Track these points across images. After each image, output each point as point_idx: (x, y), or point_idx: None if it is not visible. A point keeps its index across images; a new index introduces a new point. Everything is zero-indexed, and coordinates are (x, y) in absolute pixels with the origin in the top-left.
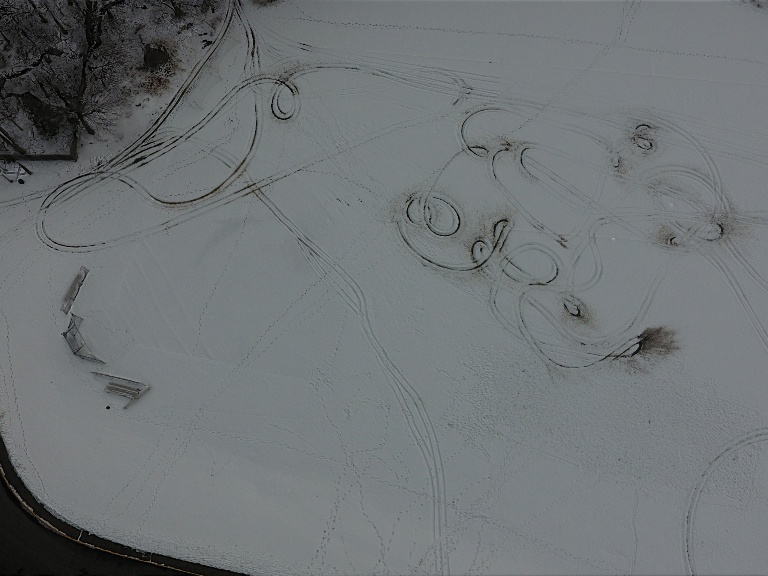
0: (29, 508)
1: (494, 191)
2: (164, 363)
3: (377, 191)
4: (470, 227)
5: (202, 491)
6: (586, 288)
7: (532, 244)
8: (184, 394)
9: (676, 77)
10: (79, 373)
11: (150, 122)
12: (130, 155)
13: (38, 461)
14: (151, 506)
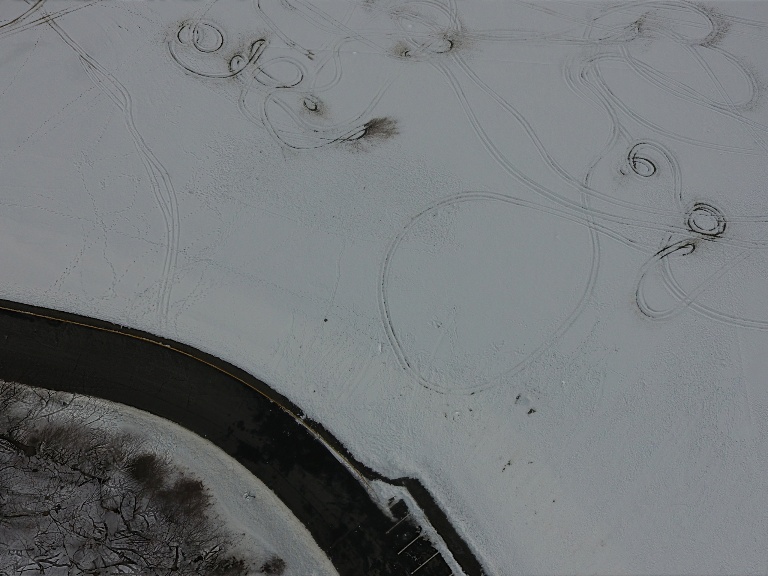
0: None
1: (256, 18)
2: None
3: (154, 19)
4: (231, 45)
5: None
6: (325, 89)
7: (283, 57)
8: None
9: None
10: None
11: None
12: None
13: None
14: None
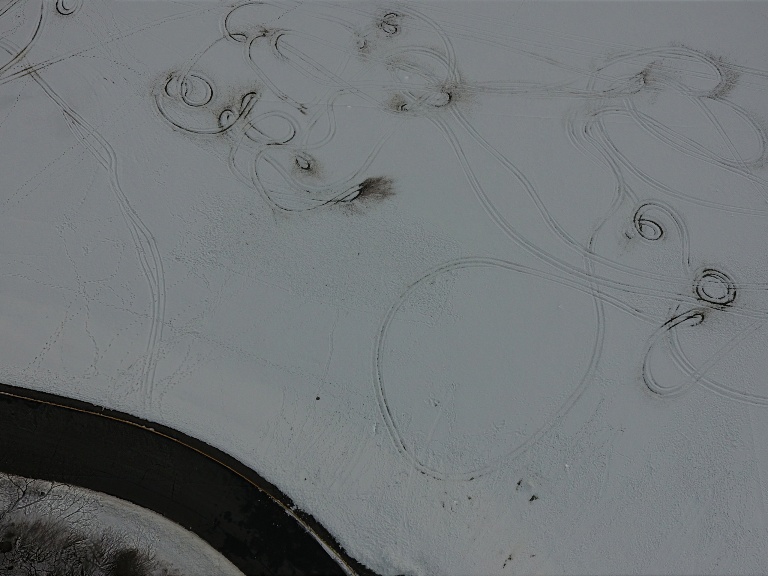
0: None
1: (247, 69)
2: None
3: (141, 71)
4: (220, 98)
5: None
6: (318, 146)
7: (275, 112)
8: None
9: None
10: None
11: None
12: None
13: None
14: None
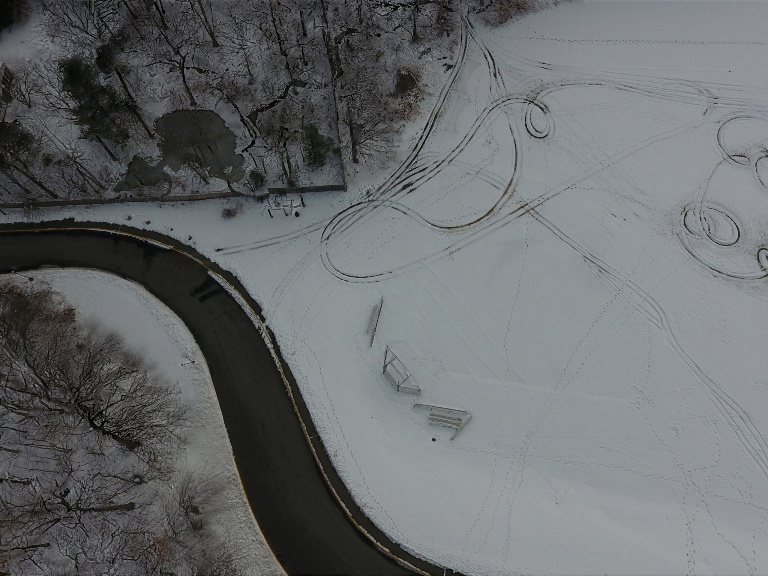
0: (385, 549)
1: (765, 198)
2: (479, 390)
3: (650, 204)
4: (751, 235)
5: (553, 520)
6: None
7: None
8: (507, 421)
9: None
10: (397, 406)
11: (409, 148)
12: (397, 182)
13: (383, 499)
14: (508, 539)
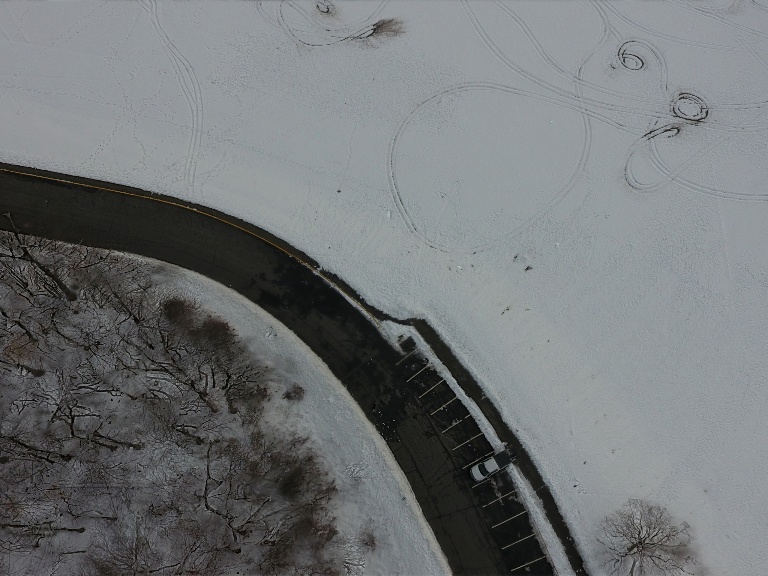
0: None
1: None
2: None
3: None
4: None
5: (7, 122)
6: None
7: None
8: (3, 65)
9: None
10: None
11: None
12: None
13: None
14: None
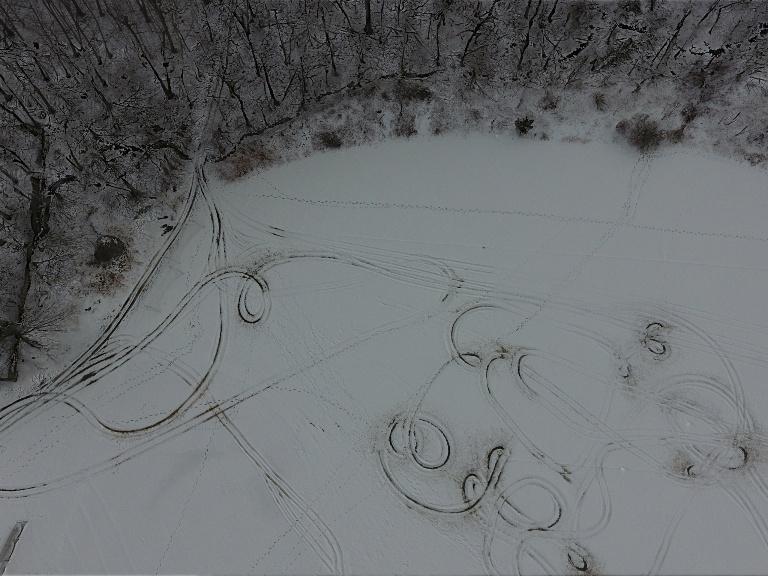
0: None
1: (488, 410)
2: None
3: (356, 413)
4: (461, 457)
5: None
6: (593, 534)
7: (531, 478)
8: None
9: (691, 263)
10: None
11: (101, 329)
12: (78, 371)
13: None
14: None
